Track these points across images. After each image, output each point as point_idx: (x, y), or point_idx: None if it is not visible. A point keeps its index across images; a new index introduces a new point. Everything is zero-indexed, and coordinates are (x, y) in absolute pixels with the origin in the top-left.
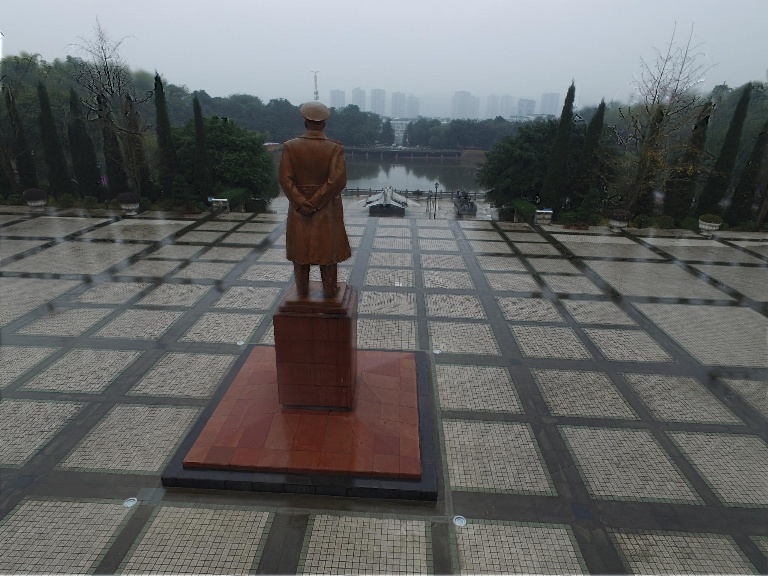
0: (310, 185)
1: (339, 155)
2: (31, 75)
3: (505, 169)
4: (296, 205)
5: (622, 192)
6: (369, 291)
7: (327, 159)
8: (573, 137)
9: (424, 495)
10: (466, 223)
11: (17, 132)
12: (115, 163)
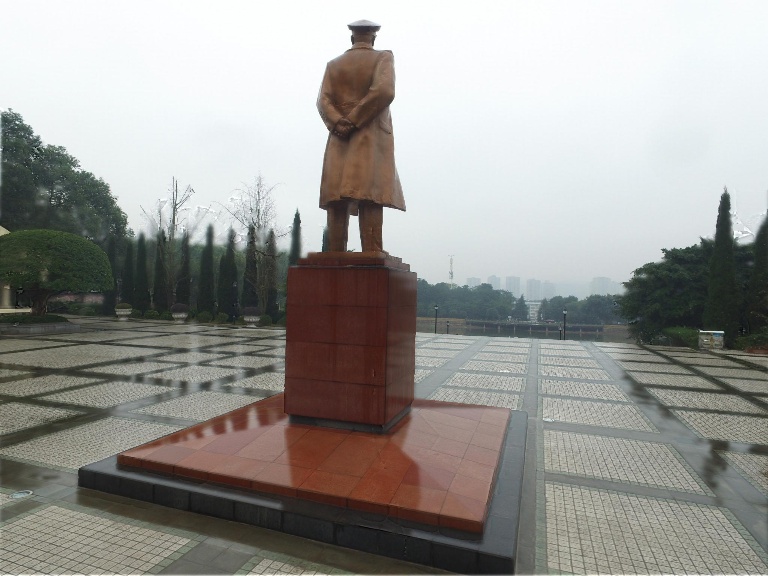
0: (350, 101)
1: (386, 61)
2: (206, 220)
3: (650, 293)
4: (331, 125)
5: None
6: (465, 372)
7: (371, 66)
8: (738, 255)
9: (484, 563)
10: (603, 343)
11: (184, 262)
12: (250, 287)
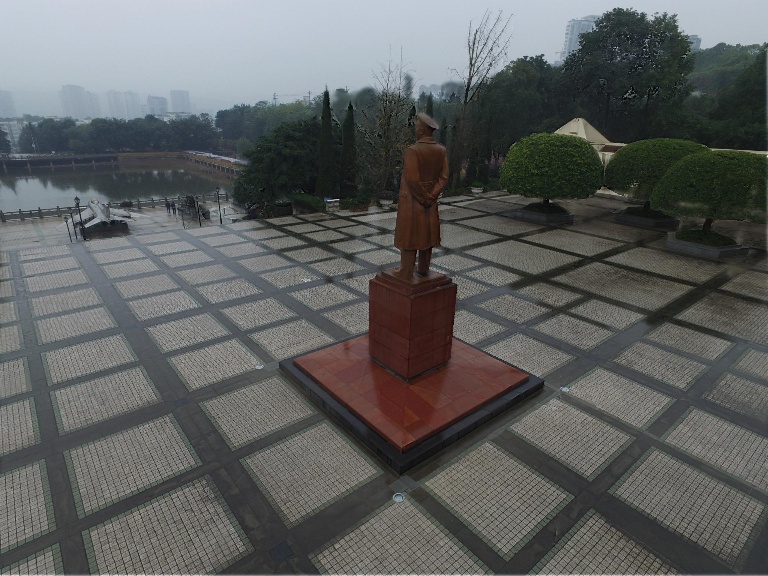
0: (429, 182)
1: None
2: None
3: (277, 167)
4: (424, 200)
5: (377, 177)
6: (293, 292)
7: (441, 159)
8: None
9: (539, 386)
10: (275, 221)
11: None
12: None
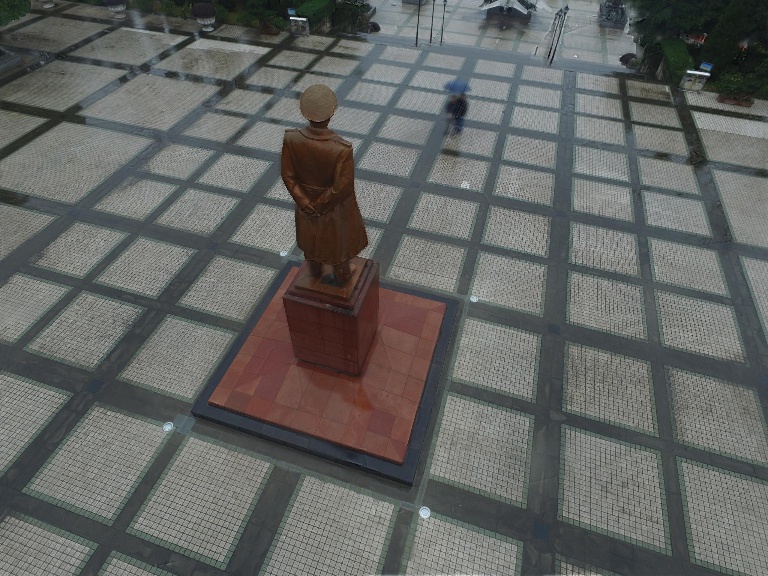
0: (314, 187)
1: (345, 161)
2: None
3: None
4: (299, 206)
5: None
6: (430, 193)
7: (331, 165)
8: None
9: (401, 481)
10: (586, 79)
11: None
12: None
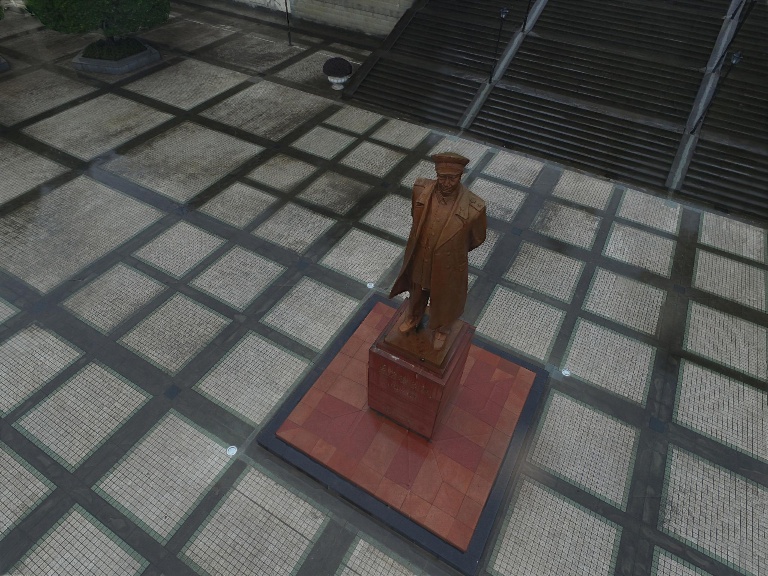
0: None
1: None
2: None
3: None
4: None
5: None
6: None
7: None
8: None
9: None
10: None
11: None
12: None
